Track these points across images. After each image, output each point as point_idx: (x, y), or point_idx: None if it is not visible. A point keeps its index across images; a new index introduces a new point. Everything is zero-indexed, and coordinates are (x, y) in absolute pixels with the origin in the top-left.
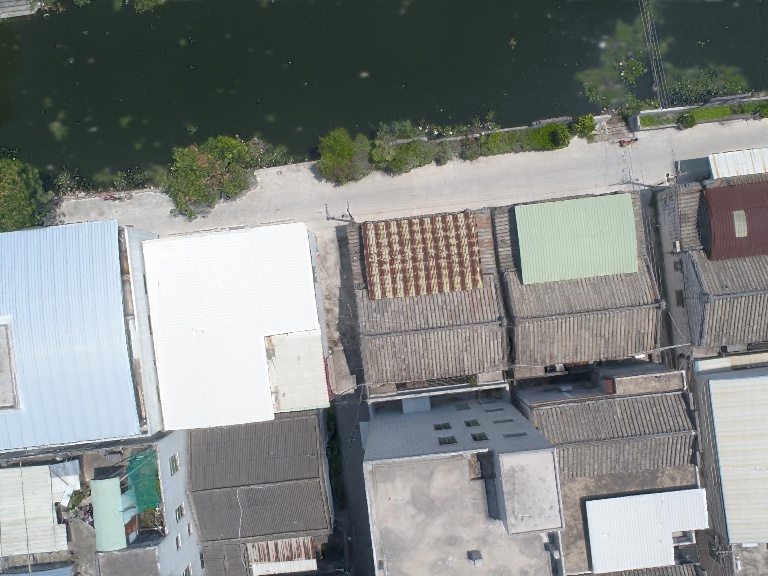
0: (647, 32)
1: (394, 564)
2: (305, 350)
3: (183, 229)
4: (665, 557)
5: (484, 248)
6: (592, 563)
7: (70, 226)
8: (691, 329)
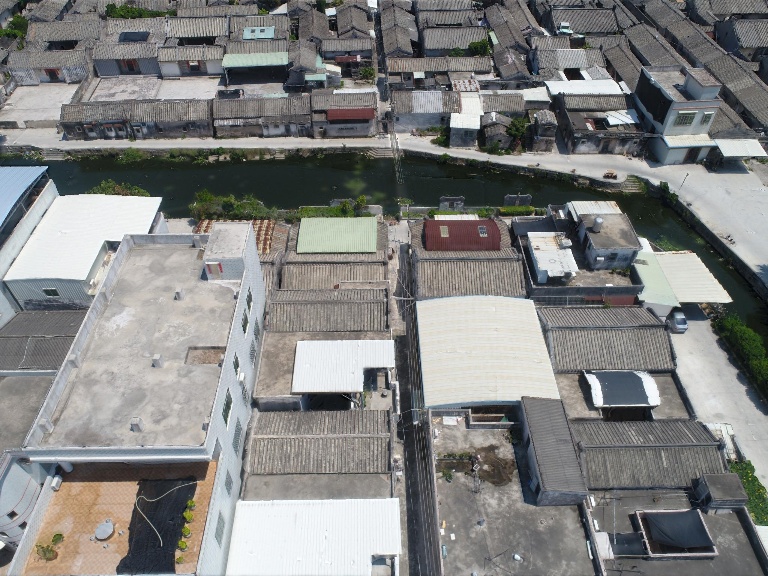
0: (395, 159)
1: (117, 299)
2: None
3: None
4: (355, 385)
5: (279, 241)
6: (292, 384)
7: (19, 167)
8: (415, 291)
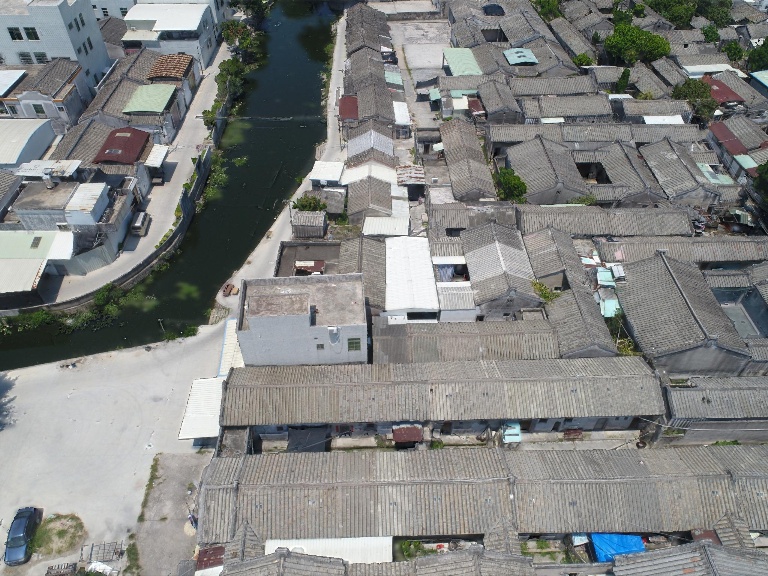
0: None
1: None
2: (148, 37)
3: (225, 46)
4: None
5: None
6: None
7: None
8: None
